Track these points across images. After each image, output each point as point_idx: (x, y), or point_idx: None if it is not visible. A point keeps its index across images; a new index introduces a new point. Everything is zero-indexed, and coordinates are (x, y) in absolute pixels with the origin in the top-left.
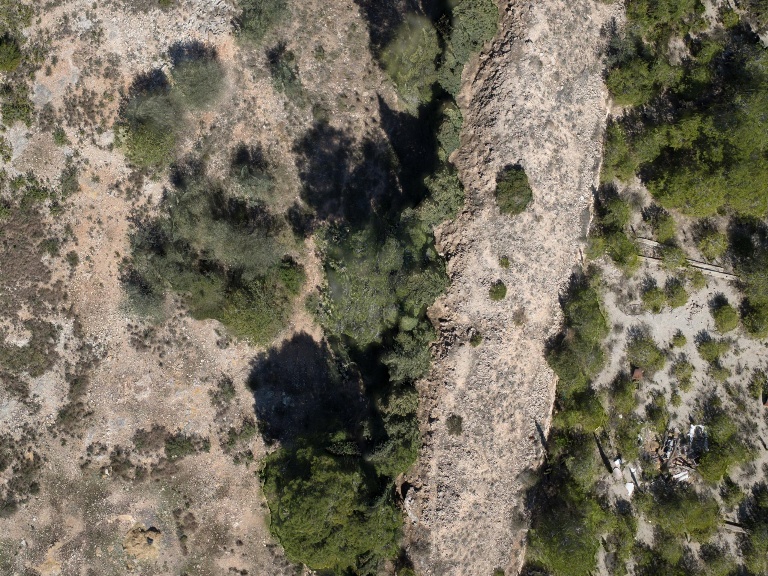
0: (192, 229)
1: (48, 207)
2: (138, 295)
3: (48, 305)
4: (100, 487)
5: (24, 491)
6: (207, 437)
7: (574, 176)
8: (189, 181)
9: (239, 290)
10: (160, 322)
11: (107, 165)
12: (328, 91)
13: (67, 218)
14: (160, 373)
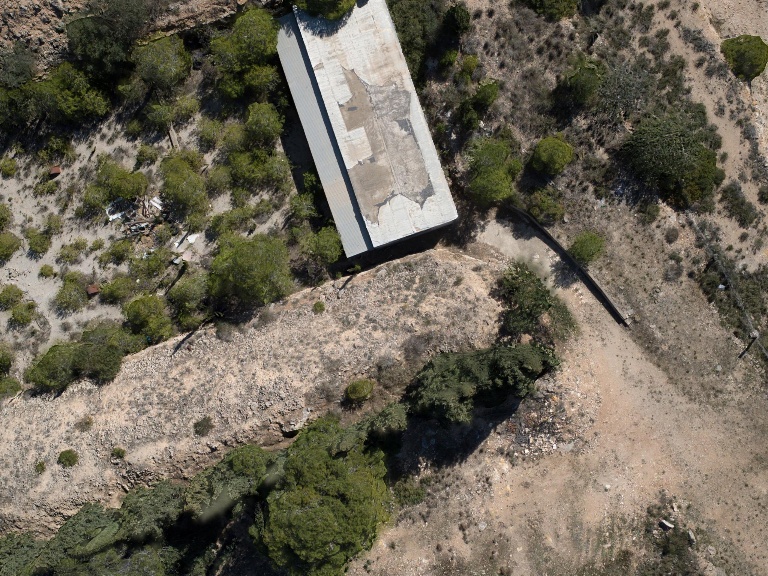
0: None
1: None
2: None
3: None
4: None
5: None
6: None
7: None
8: None
9: None
10: None
11: None
12: None
13: None
14: None
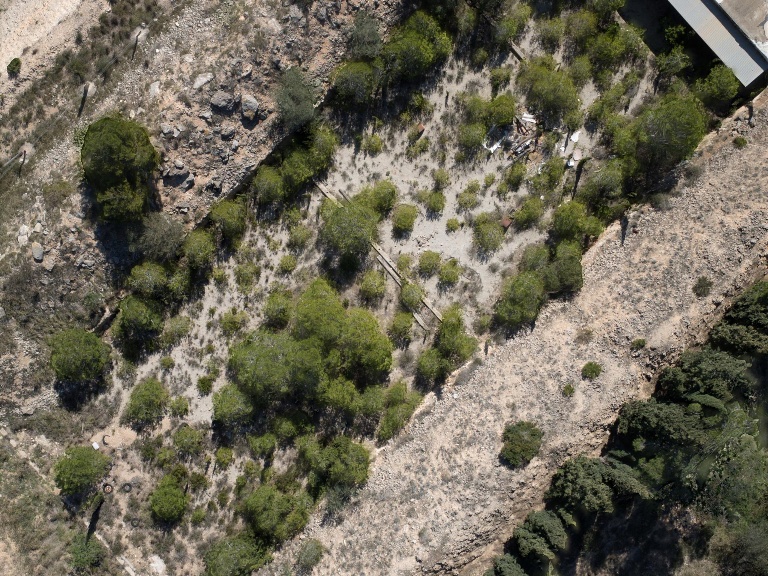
0: None
1: None
2: None
3: None
4: None
5: None
6: None
7: (451, 419)
8: None
9: None
10: None
11: None
12: None
13: None
14: None
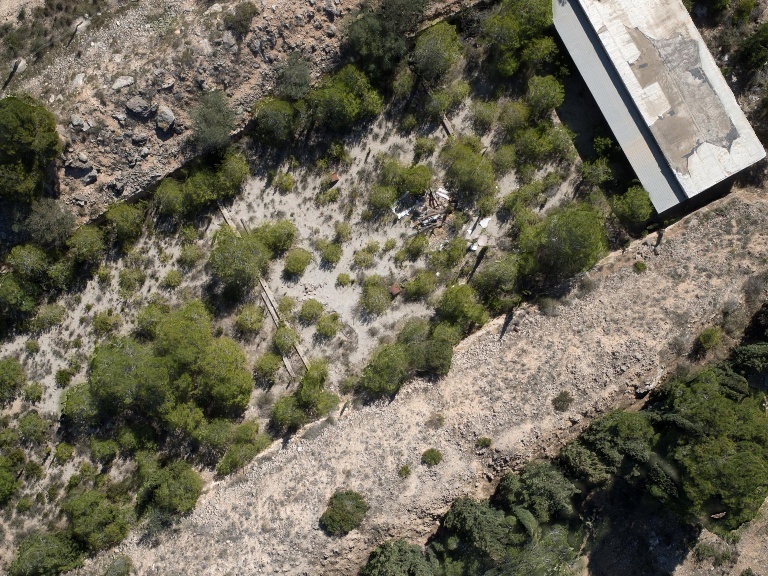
0: None
1: None
2: None
3: None
4: None
5: None
6: None
7: (288, 470)
8: None
9: None
10: None
11: None
12: None
13: None
14: None
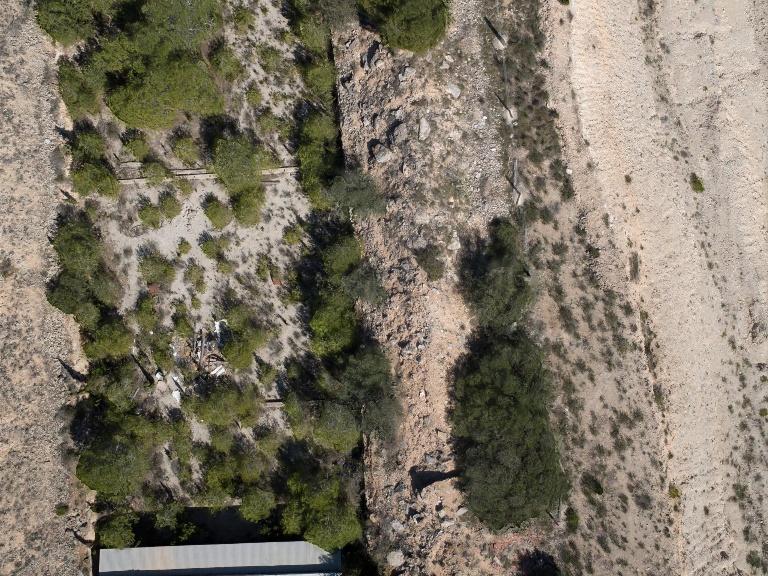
0: None
1: None
2: None
3: None
4: None
5: None
6: None
7: (32, 123)
8: None
9: None
10: None
11: None
12: None
13: None
14: None
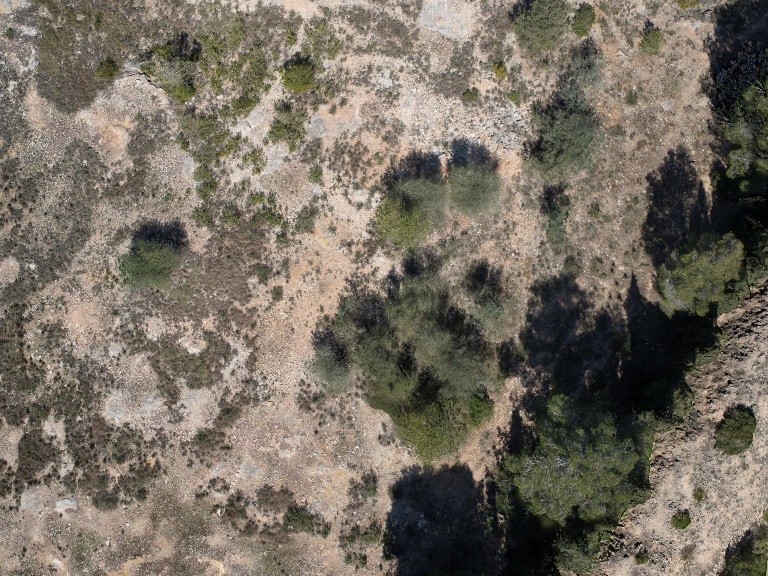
0: (409, 322)
1: (276, 234)
2: (327, 358)
3: (234, 326)
4: (205, 523)
5: (131, 493)
6: (330, 523)
7: None
8: (420, 272)
9: (434, 404)
10: (334, 392)
11: (349, 221)
12: (587, 249)
13: (289, 253)
14: (312, 440)
